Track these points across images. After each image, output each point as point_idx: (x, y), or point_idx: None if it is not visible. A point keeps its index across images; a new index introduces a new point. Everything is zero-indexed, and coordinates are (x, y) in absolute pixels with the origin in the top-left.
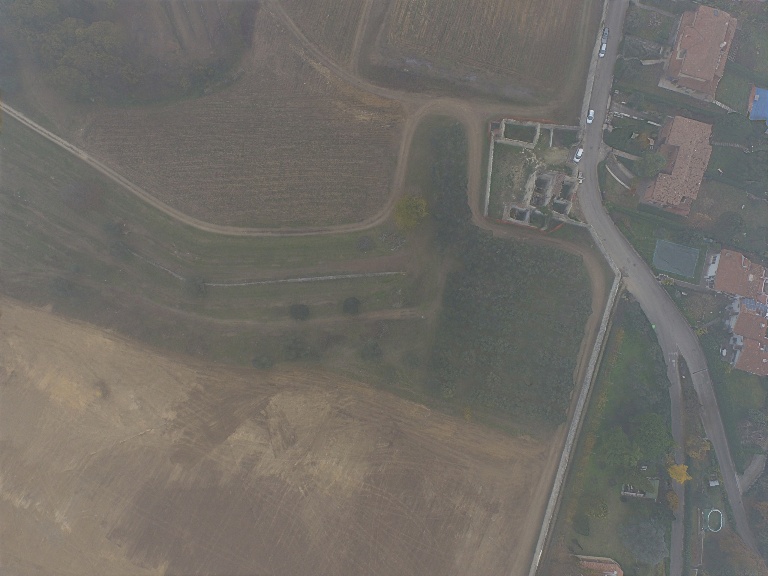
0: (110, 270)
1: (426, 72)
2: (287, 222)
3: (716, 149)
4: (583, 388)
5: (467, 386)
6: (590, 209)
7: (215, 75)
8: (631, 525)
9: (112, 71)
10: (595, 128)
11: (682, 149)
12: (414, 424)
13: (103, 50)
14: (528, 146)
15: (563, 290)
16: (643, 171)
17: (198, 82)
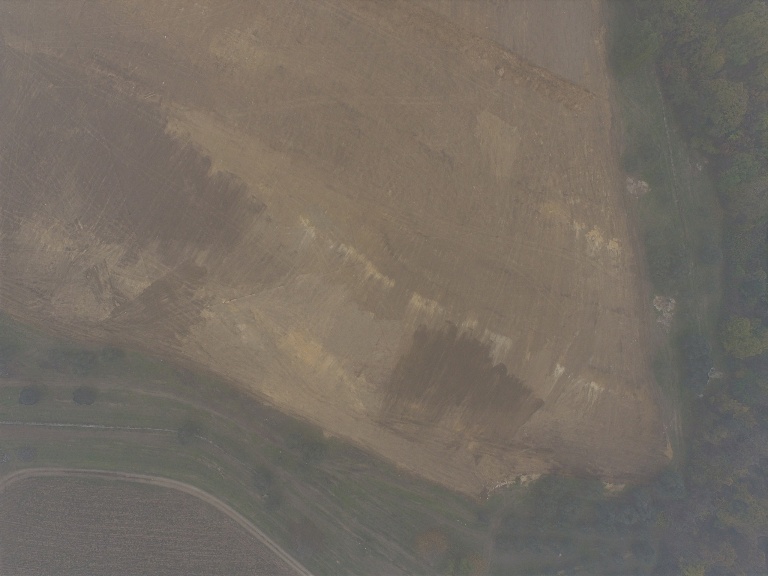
0: None
1: None
2: (108, 485)
3: None
4: None
5: None
6: None
7: None
8: None
9: None
10: None
11: None
12: None
13: None
14: None
15: None
16: None
17: None
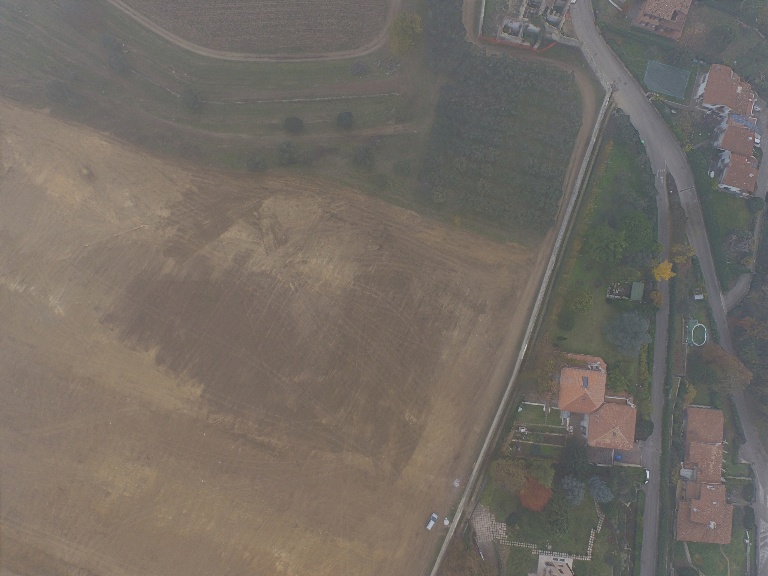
0: (108, 83)
1: None
2: (284, 48)
3: None
4: (572, 197)
5: (457, 196)
6: (583, 29)
7: None
8: (615, 319)
9: None
10: None
11: None
12: (404, 229)
13: None
14: None
15: (554, 103)
16: None
17: None
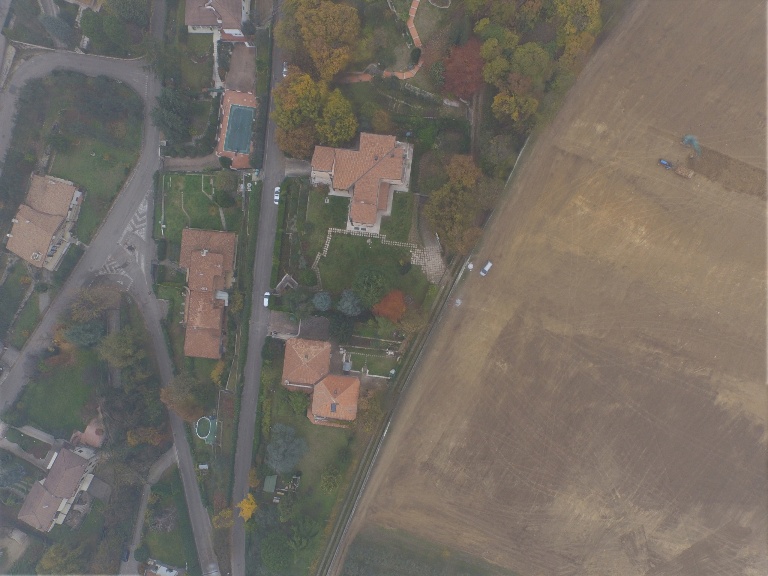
0: None
1: None
2: None
3: None
4: None
5: None
6: None
7: None
8: None
9: None
10: None
11: None
12: (500, 546)
13: None
14: None
15: None
16: None
17: None
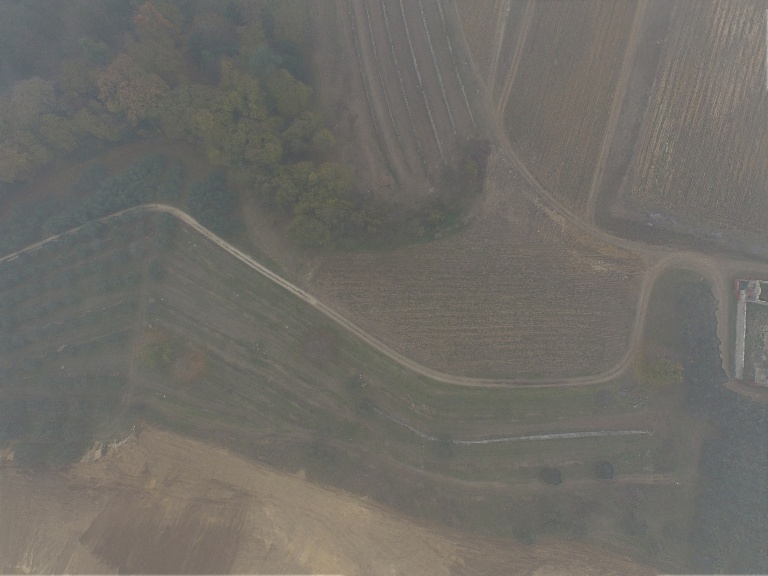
0: (354, 428)
1: (671, 227)
2: (522, 373)
3: None
4: None
5: (731, 560)
6: None
7: (446, 220)
8: None
9: (345, 217)
10: None
11: None
12: None
13: (335, 195)
14: None
15: None
16: None
17: (428, 227)
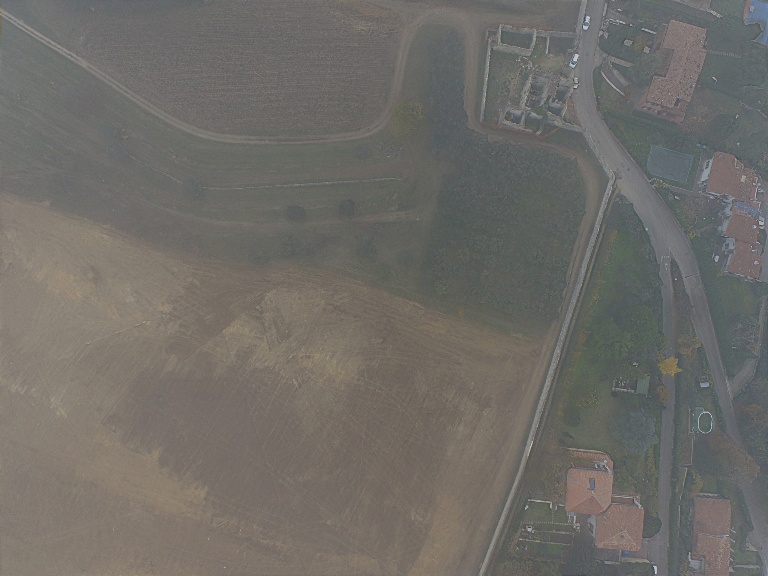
0: (108, 171)
1: None
2: (284, 130)
3: (711, 58)
4: (576, 287)
5: (461, 285)
6: (585, 114)
7: None
8: (621, 416)
9: None
10: (591, 35)
11: (677, 52)
12: (408, 321)
13: None
14: (524, 53)
15: (557, 191)
16: (638, 74)
17: None
